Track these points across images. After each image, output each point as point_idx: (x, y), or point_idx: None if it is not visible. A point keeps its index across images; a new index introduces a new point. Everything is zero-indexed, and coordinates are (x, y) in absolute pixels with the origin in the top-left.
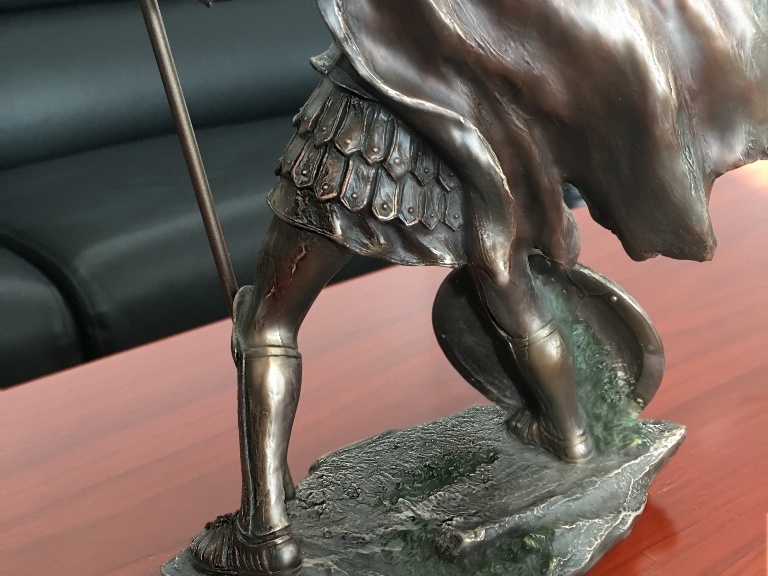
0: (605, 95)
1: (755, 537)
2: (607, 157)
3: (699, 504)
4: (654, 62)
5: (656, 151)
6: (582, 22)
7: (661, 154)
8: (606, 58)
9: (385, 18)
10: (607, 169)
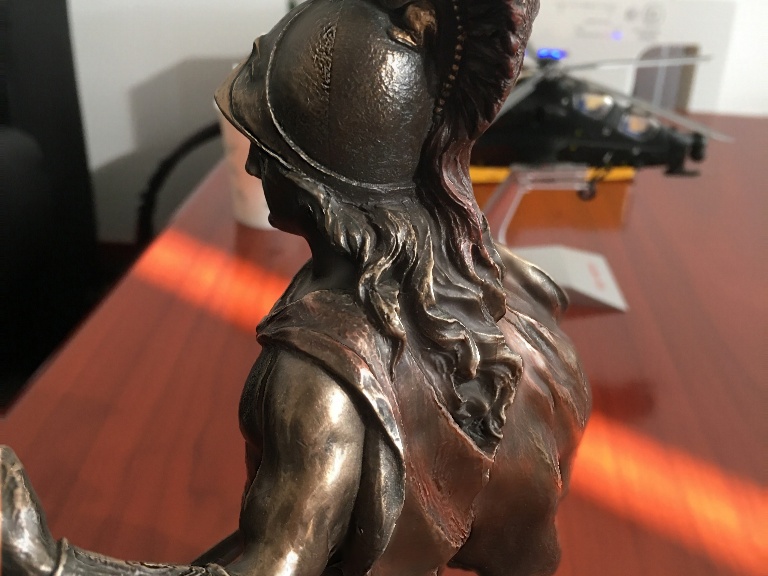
0: (512, 505)
1: None
2: (495, 539)
3: None
4: (555, 472)
5: (545, 528)
6: (511, 466)
7: (547, 528)
8: (523, 483)
9: (395, 566)
10: (493, 546)
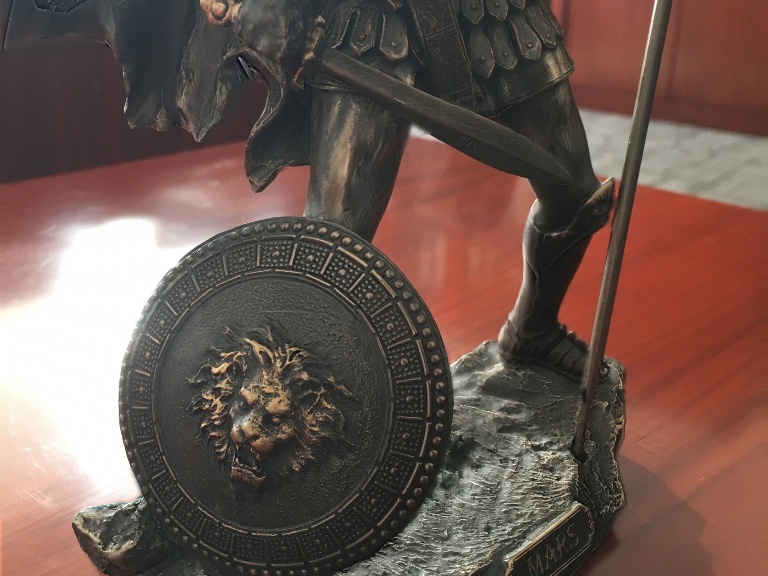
0: None
1: (37, 535)
2: None
3: (75, 575)
4: None
5: None
6: None
7: None
8: None
9: None
10: None
